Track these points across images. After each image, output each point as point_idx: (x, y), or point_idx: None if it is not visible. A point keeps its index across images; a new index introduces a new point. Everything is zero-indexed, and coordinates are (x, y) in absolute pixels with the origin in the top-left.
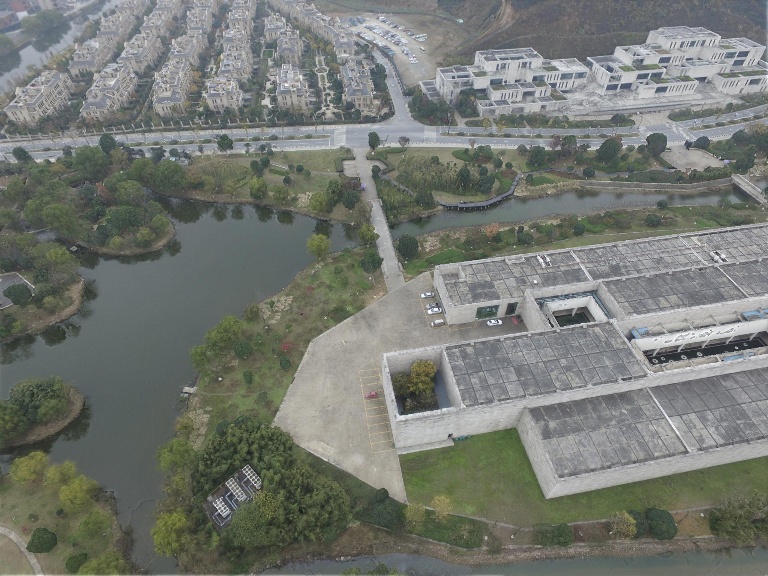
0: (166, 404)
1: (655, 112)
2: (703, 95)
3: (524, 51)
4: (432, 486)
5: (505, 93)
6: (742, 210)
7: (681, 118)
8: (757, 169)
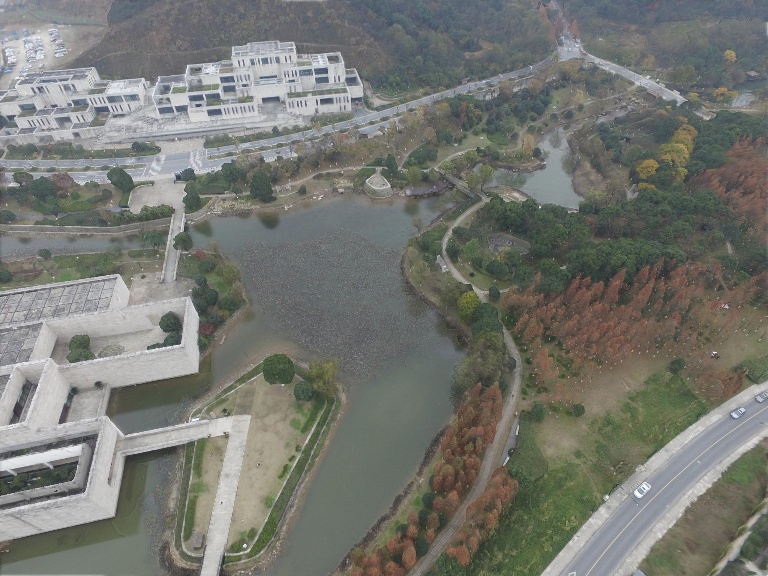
0: None
1: (197, 138)
2: (267, 117)
3: (81, 71)
4: None
5: (31, 120)
6: (135, 258)
7: (214, 145)
8: (220, 205)
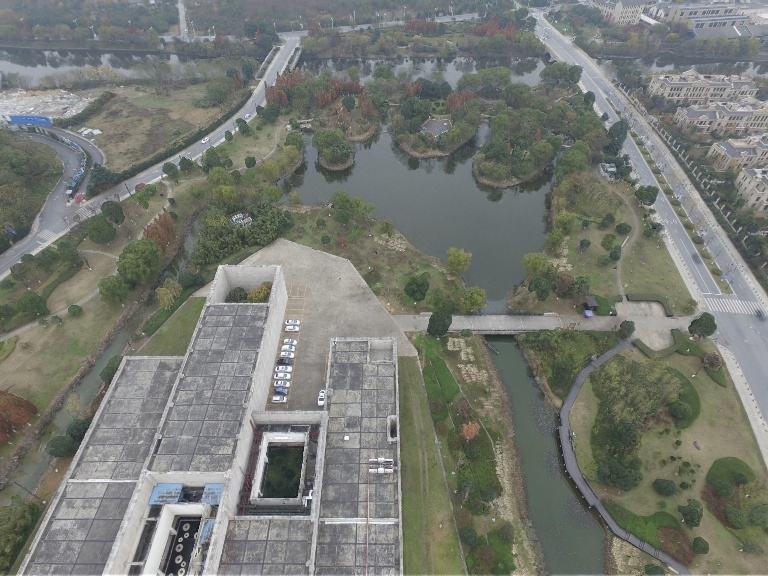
0: (324, 198)
1: None
2: None
3: None
4: (193, 311)
5: None
6: None
7: None
8: None
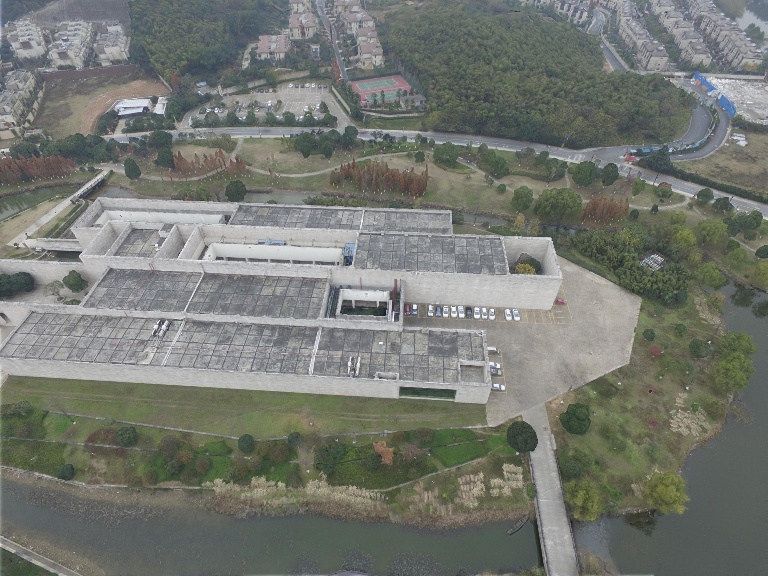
0: None
1: None
2: None
3: None
4: None
5: None
6: None
7: None
8: None
